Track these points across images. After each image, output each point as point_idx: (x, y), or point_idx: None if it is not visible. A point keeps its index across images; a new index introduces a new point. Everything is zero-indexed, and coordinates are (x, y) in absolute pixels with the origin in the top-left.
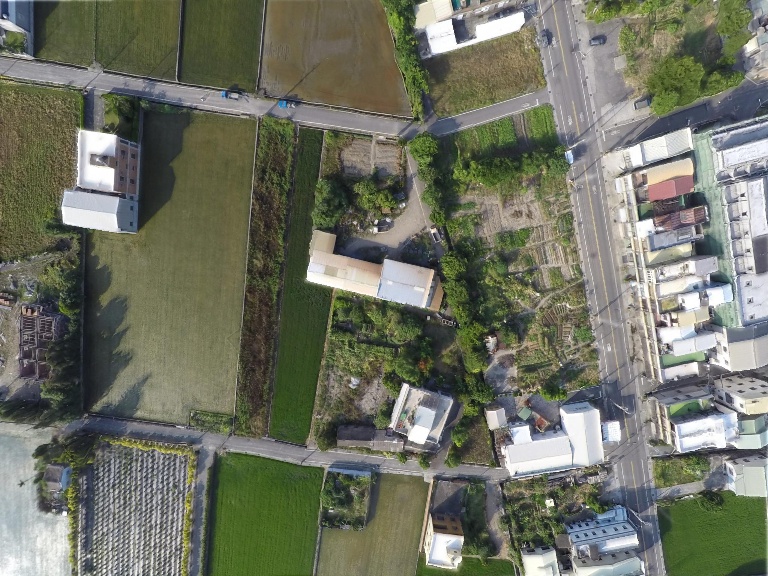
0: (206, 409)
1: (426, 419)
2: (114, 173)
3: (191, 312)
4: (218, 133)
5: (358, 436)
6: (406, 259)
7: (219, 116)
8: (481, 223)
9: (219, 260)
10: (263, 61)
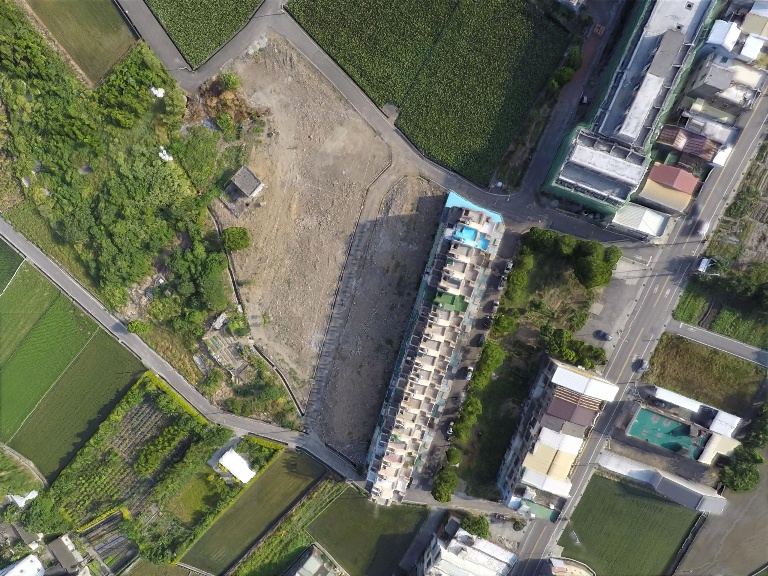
0: None
1: None
2: None
3: None
4: None
5: None
6: None
7: None
8: None
9: None
10: None
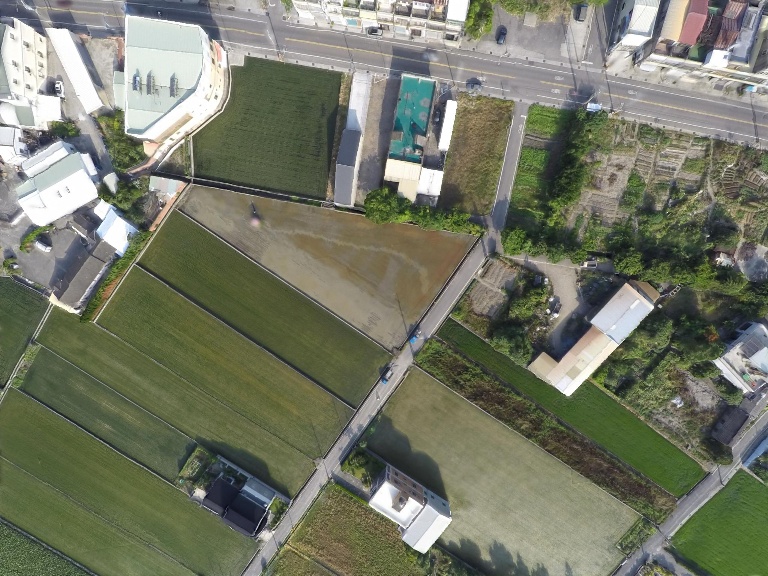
0: (621, 534)
1: (767, 359)
2: (412, 499)
3: (533, 499)
4: (408, 401)
5: (735, 425)
6: (595, 301)
7: (396, 393)
8: (602, 217)
9: (505, 455)
10: (373, 337)
